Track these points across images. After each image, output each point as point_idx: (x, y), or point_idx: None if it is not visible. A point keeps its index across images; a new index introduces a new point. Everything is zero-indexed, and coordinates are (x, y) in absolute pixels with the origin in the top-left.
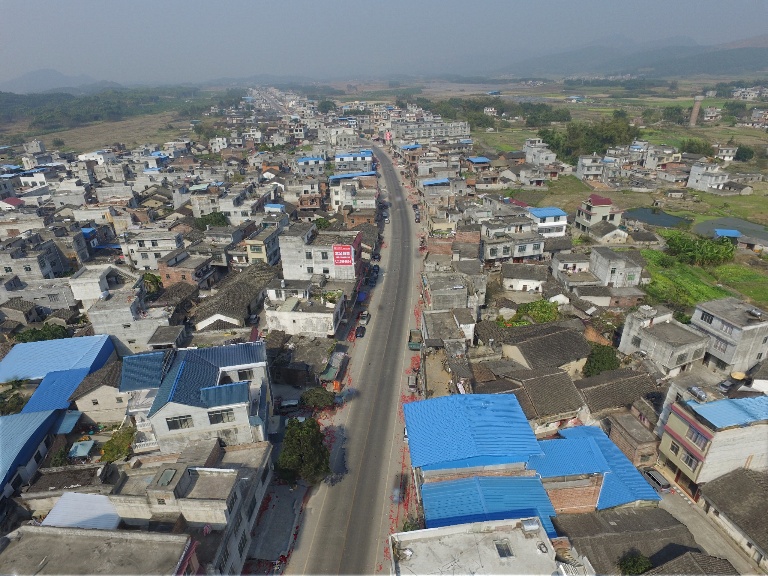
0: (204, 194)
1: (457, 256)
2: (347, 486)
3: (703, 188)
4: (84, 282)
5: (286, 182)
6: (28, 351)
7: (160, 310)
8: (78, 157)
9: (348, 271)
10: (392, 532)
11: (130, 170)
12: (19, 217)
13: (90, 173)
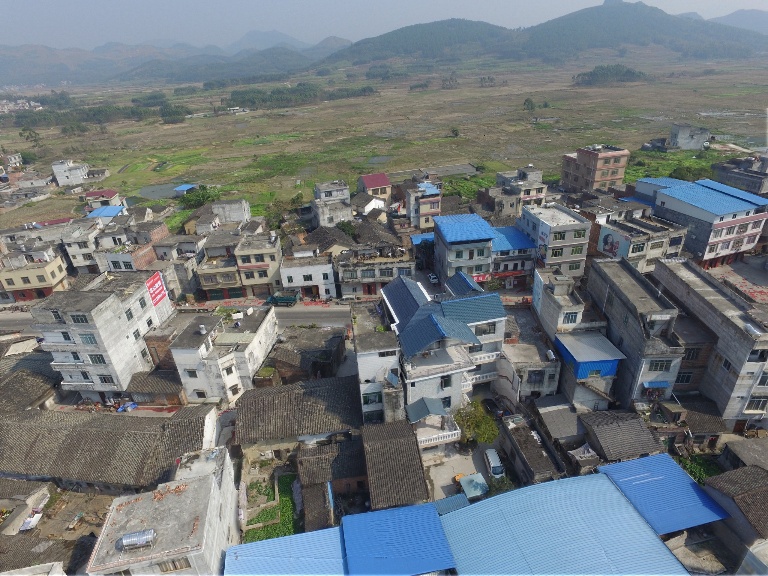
0: None
1: (175, 252)
2: None
3: (78, 181)
4: None
5: None
6: None
7: (187, 472)
8: None
9: (166, 306)
10: None
11: None
12: None
13: None
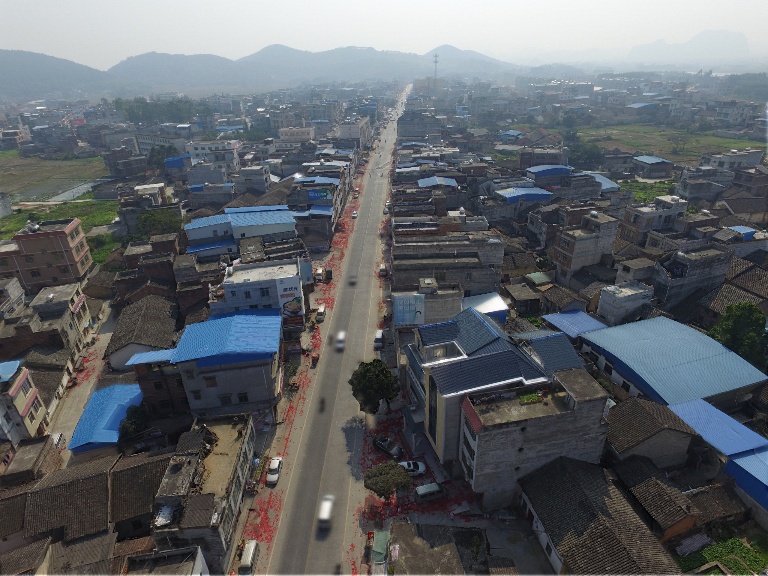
0: None
1: None
2: (341, 417)
3: None
4: None
5: None
6: None
7: None
8: None
9: None
10: (304, 391)
11: None
12: None
13: None
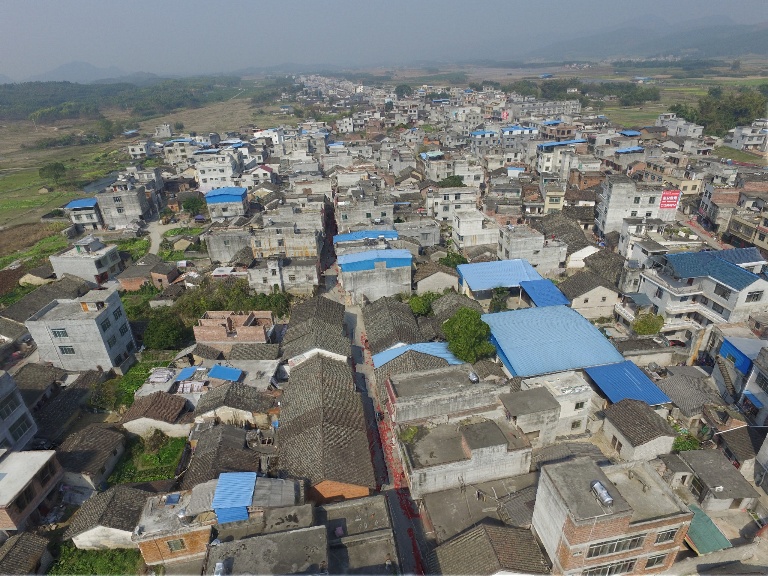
0: (442, 160)
1: (750, 203)
2: None
3: None
4: (472, 220)
5: (483, 152)
6: (475, 269)
7: (550, 241)
8: (254, 135)
9: (670, 214)
10: None
11: (311, 145)
12: (308, 178)
13: (284, 147)
